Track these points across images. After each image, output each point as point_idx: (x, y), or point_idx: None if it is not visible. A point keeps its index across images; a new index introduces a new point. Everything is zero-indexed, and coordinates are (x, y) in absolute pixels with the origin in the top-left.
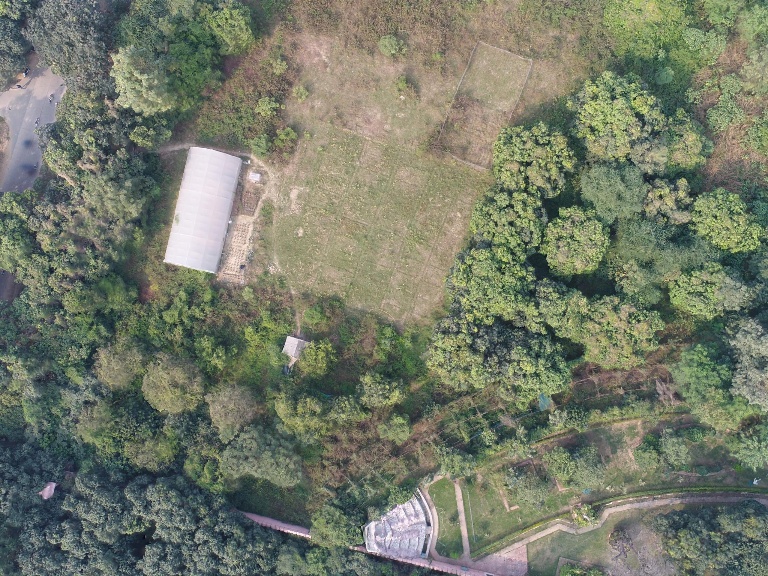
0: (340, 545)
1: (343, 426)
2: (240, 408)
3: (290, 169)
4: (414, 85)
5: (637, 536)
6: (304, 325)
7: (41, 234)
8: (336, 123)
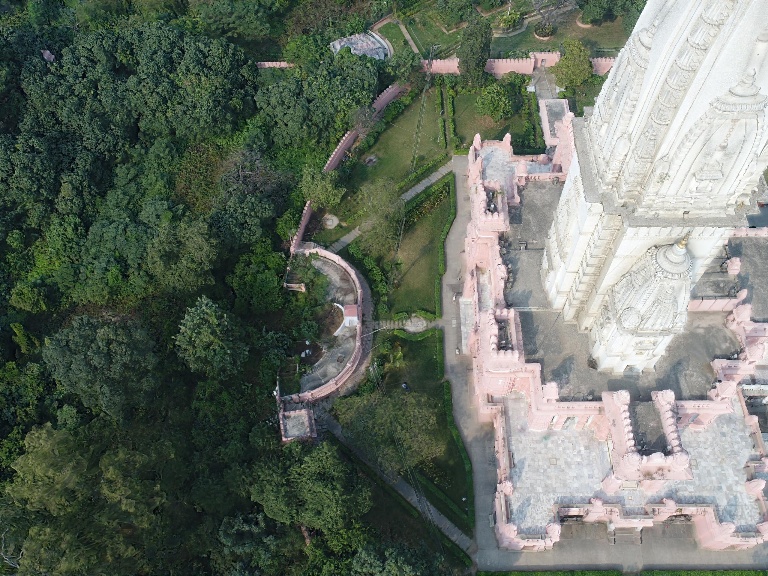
0: (312, 59)
1: None
2: None
3: None
4: None
5: (557, 31)
6: None
7: None
8: None
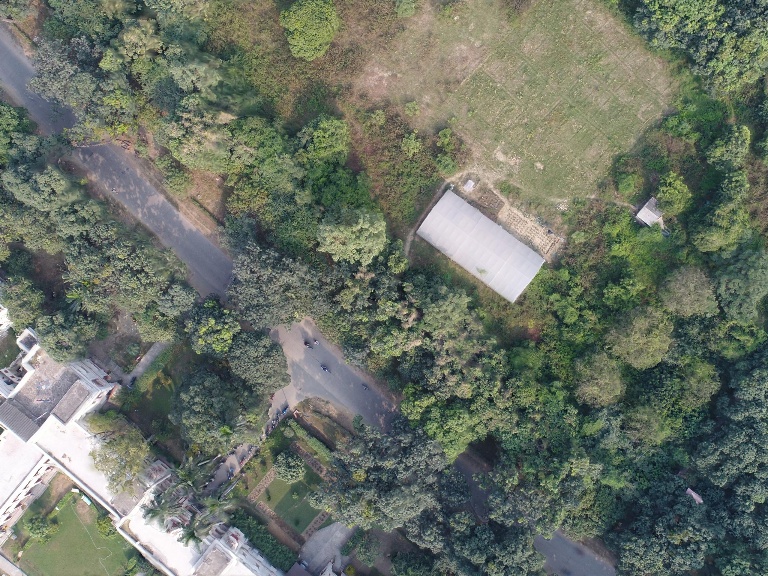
0: None
1: (743, 201)
2: (697, 280)
3: (476, 151)
4: (451, 2)
5: None
6: (630, 199)
7: (458, 390)
8: (453, 89)
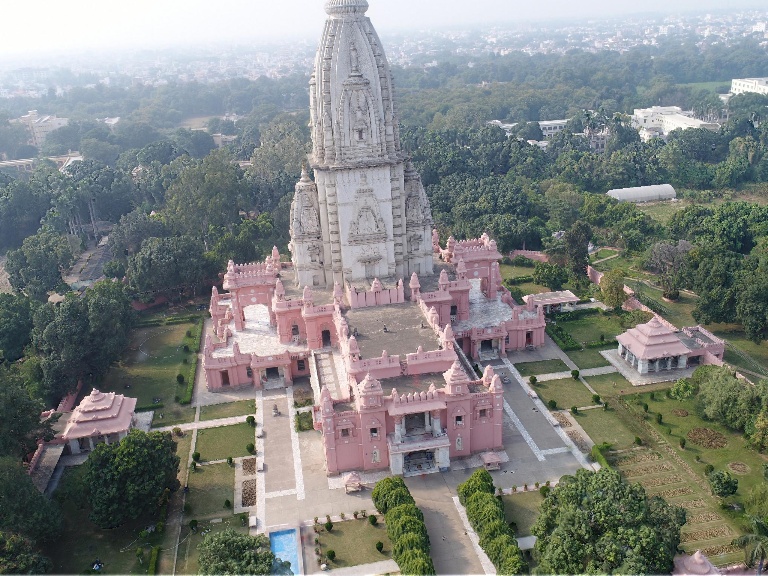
0: None
1: None
2: (575, 196)
3: None
4: None
5: None
6: None
7: None
8: None
